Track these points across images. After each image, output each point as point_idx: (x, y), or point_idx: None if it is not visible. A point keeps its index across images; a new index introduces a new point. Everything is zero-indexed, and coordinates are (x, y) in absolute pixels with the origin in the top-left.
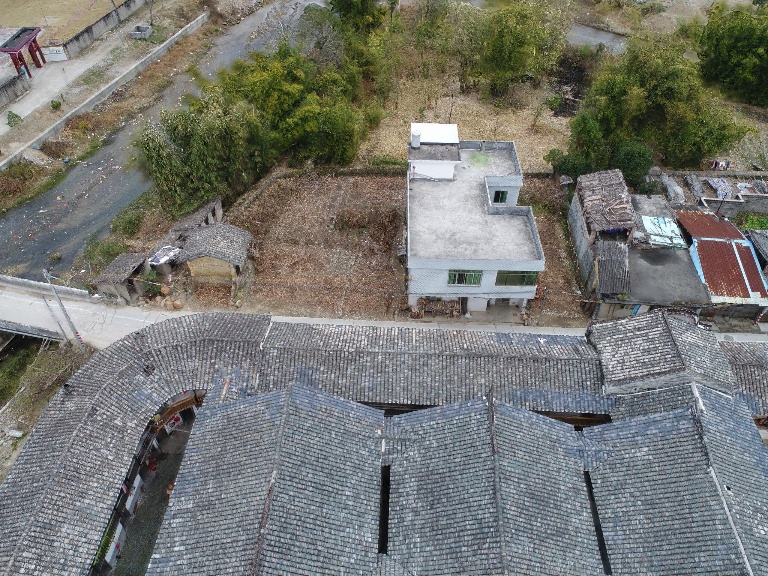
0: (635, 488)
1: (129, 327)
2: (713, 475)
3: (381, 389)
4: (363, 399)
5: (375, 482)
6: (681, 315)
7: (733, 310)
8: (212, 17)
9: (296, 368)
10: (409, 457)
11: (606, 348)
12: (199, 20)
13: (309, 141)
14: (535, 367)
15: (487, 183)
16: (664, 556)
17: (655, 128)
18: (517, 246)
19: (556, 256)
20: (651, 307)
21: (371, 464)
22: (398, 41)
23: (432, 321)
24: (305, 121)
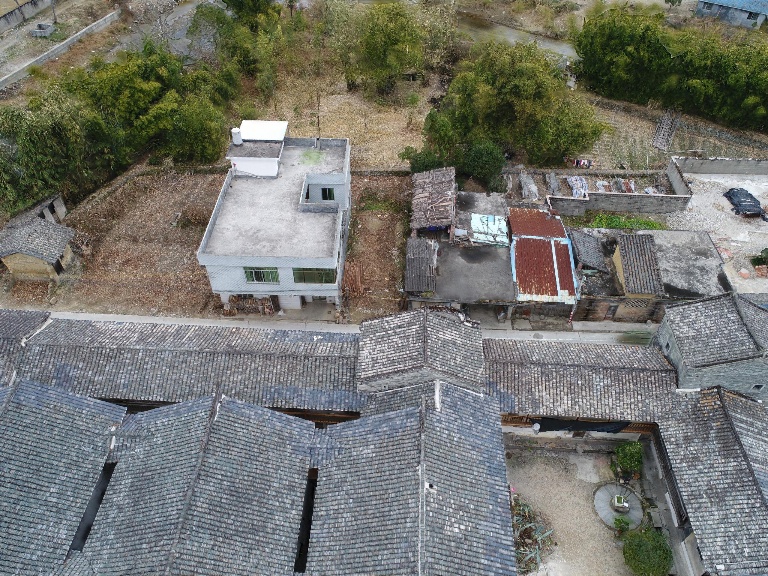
0: (352, 486)
1: None
2: (419, 473)
3: (136, 386)
4: (116, 396)
5: (91, 479)
6: (445, 312)
7: (547, 308)
8: (122, 15)
9: (55, 365)
10: (135, 454)
11: (366, 345)
12: (108, 18)
13: (168, 139)
14: (293, 364)
15: (307, 180)
16: (354, 554)
17: (511, 126)
18: (317, 243)
19: (388, 254)
20: (464, 305)
21: (92, 461)
22: (297, 39)
23: (244, 319)
24: (159, 118)
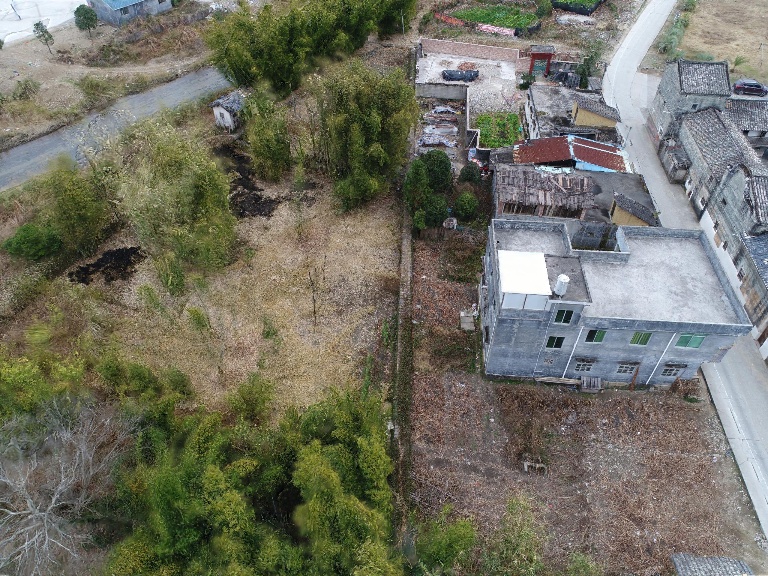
0: None
1: None
2: None
3: None
4: None
5: None
6: None
7: None
8: None
9: None
10: None
11: None
12: None
13: None
14: None
15: None
16: None
17: None
18: (673, 249)
19: None
20: None
21: None
22: None
23: None
24: None
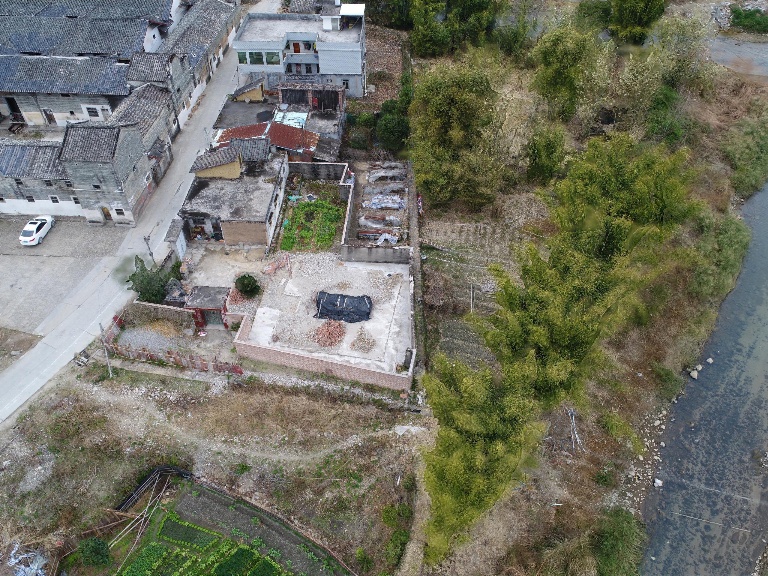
0: None
1: (269, 7)
2: None
3: None
4: None
5: None
6: None
7: None
8: None
9: None
10: None
11: None
12: None
13: None
14: None
15: (314, 36)
16: None
17: None
18: None
19: None
20: None
21: None
22: None
23: None
24: None
